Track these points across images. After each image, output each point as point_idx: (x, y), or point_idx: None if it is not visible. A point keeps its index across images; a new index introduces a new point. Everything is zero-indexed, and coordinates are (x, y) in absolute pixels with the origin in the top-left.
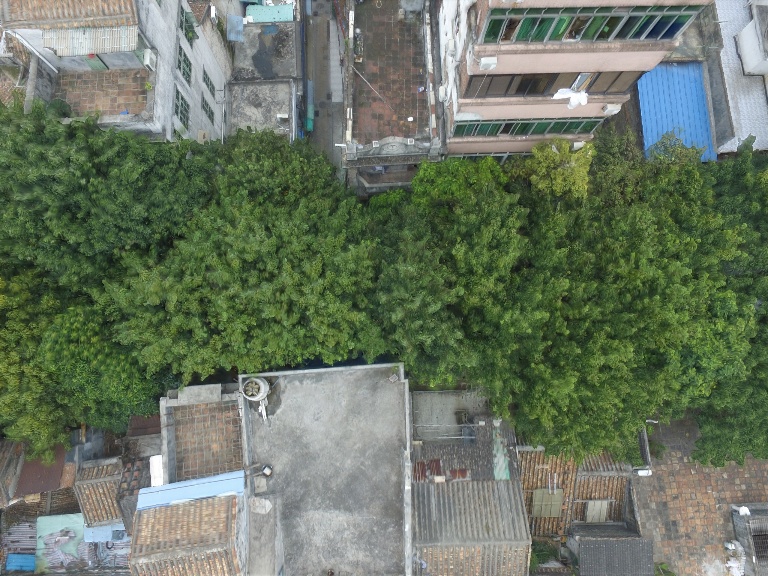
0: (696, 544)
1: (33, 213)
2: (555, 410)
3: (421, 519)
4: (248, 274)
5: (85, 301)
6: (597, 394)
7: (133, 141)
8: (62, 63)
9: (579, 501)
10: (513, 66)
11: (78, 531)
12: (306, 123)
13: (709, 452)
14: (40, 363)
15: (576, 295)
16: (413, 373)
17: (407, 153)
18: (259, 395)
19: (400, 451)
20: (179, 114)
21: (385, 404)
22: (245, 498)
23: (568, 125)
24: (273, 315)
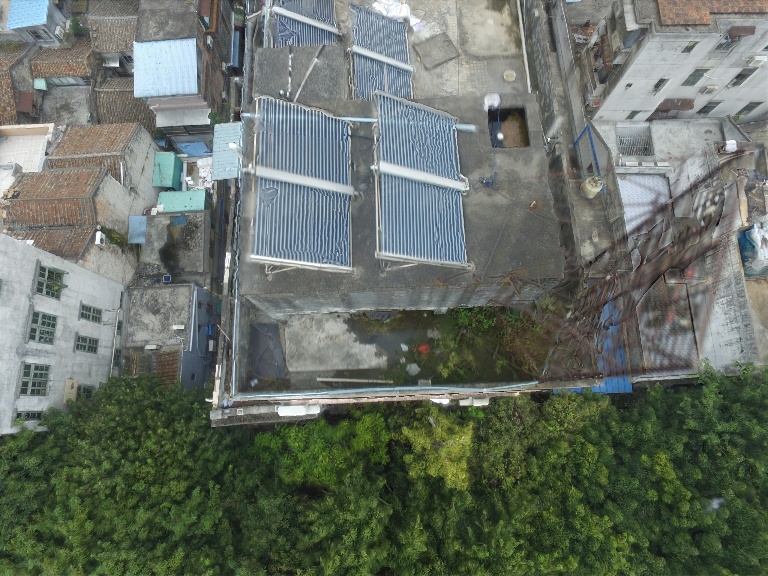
0: None
1: None
2: None
3: None
4: None
5: None
6: None
7: None
8: None
9: None
10: None
11: None
12: (219, 308)
13: None
14: None
15: None
16: None
17: None
18: None
19: None
20: (29, 388)
21: None
22: None
23: None
24: None
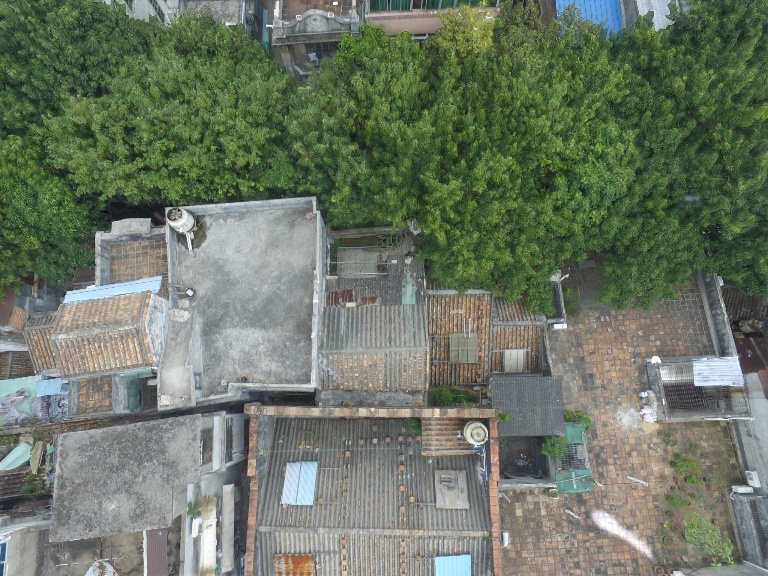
0: (612, 394)
1: None
2: (447, 224)
3: (329, 333)
4: None
5: None
6: (485, 208)
7: None
8: None
9: (496, 351)
10: None
11: (32, 391)
12: (260, 44)
13: (612, 292)
14: None
15: (466, 121)
16: (325, 206)
17: (331, 31)
18: (181, 220)
19: (313, 277)
20: None
21: (301, 238)
22: (165, 306)
23: None
24: (187, 133)
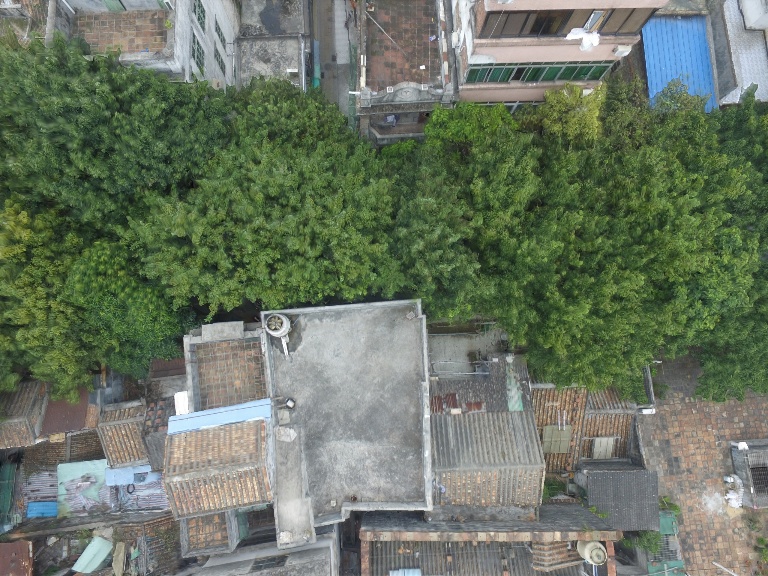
0: (697, 478)
1: (58, 148)
2: (568, 339)
3: (439, 447)
4: (271, 209)
5: (107, 242)
6: (609, 323)
7: None
8: (80, 3)
9: (586, 438)
10: (530, 1)
11: (99, 476)
12: (313, 82)
13: (711, 387)
14: (68, 296)
15: (589, 229)
16: (430, 309)
17: (420, 100)
18: (282, 329)
19: (418, 384)
20: (195, 58)
21: (403, 340)
22: (271, 426)
23: (578, 70)
24: (297, 246)
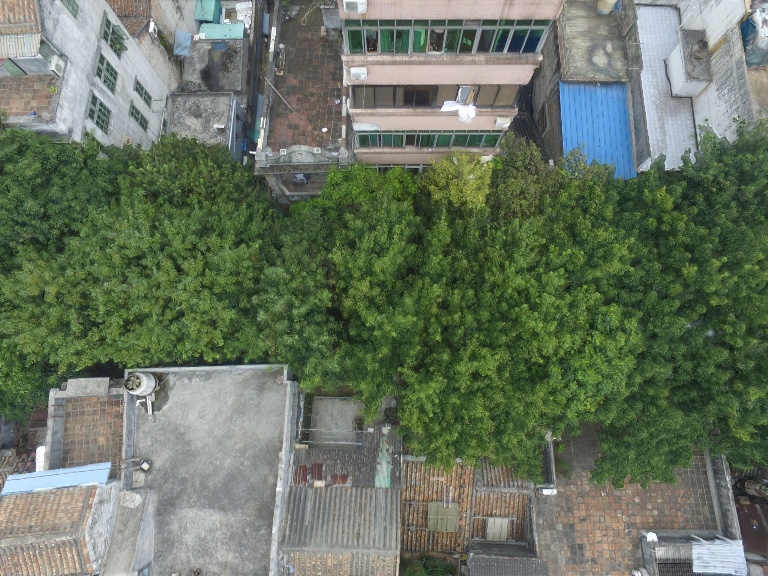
0: (602, 570)
1: None
2: (426, 417)
3: (293, 523)
4: (131, 269)
5: None
6: (468, 402)
7: (36, 141)
8: None
9: (479, 517)
10: (388, 77)
11: None
12: (253, 135)
13: (606, 471)
14: None
15: (452, 302)
16: (297, 375)
17: (318, 162)
18: (140, 389)
19: None
20: (95, 119)
21: (270, 405)
22: (115, 491)
23: (470, 138)
24: (146, 309)
